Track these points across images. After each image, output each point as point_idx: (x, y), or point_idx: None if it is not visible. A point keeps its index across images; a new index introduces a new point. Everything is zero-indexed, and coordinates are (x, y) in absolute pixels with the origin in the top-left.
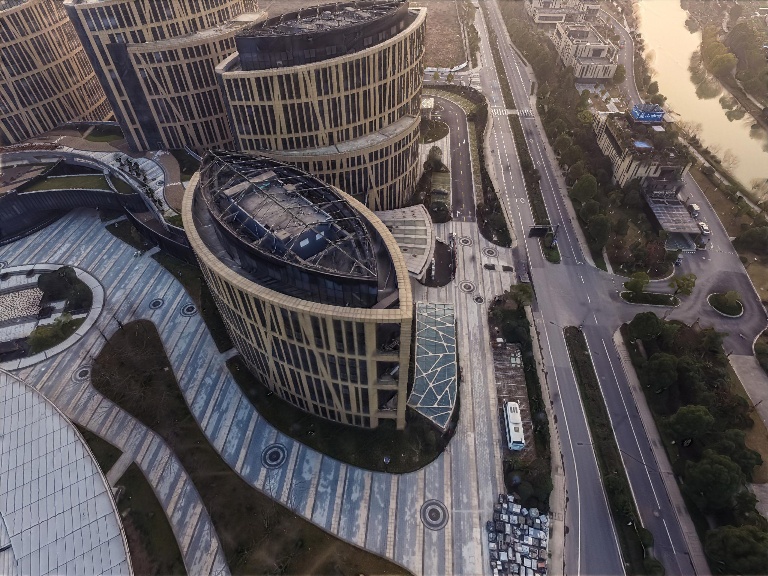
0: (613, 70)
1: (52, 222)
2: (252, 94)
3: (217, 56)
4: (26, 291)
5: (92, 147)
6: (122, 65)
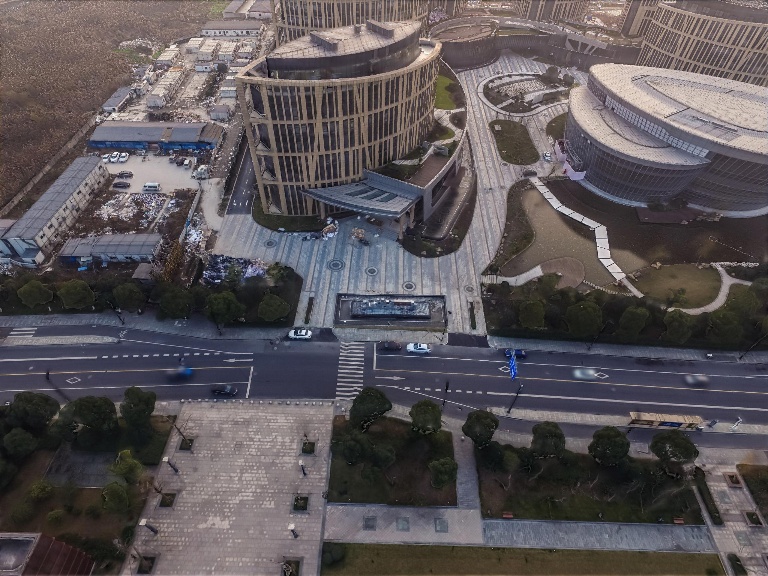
0: None
1: (498, 58)
2: None
3: None
4: (528, 81)
5: None
6: None
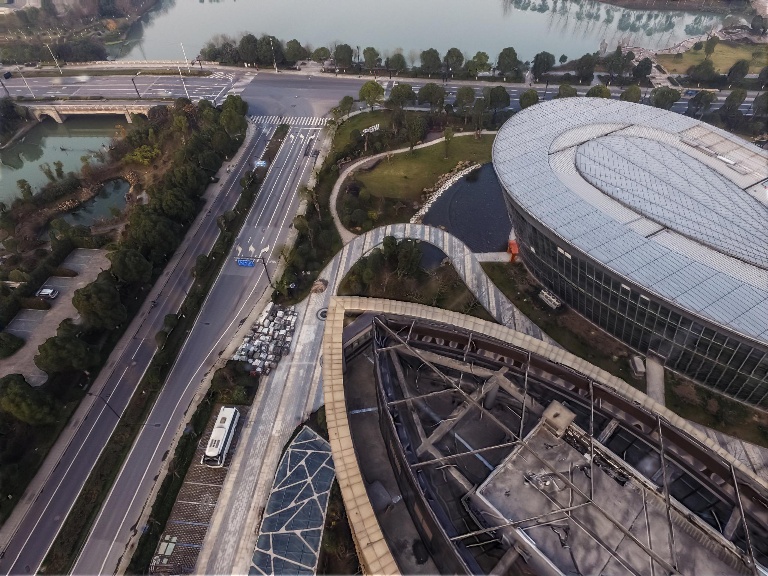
0: None
1: None
2: None
3: None
4: None
5: None
6: None
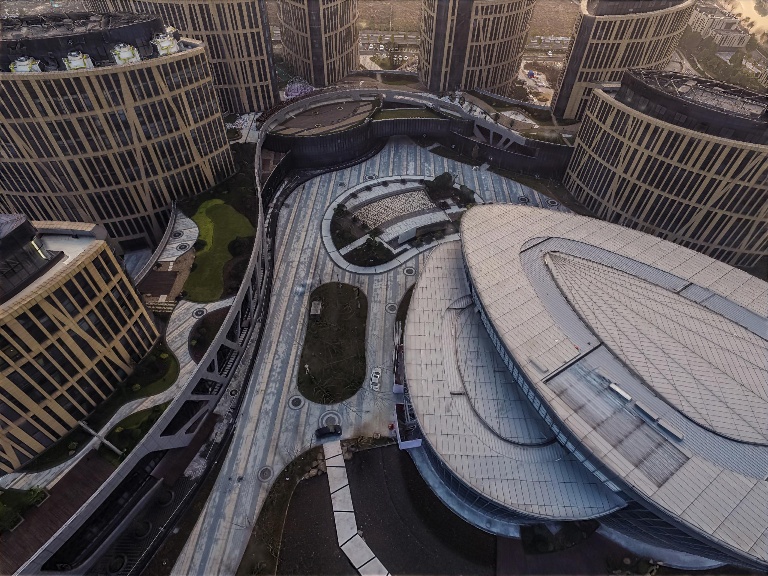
0: (747, 40)
1: (382, 148)
2: (611, 34)
3: (522, 11)
4: (410, 193)
5: (396, 89)
6: (462, 16)
